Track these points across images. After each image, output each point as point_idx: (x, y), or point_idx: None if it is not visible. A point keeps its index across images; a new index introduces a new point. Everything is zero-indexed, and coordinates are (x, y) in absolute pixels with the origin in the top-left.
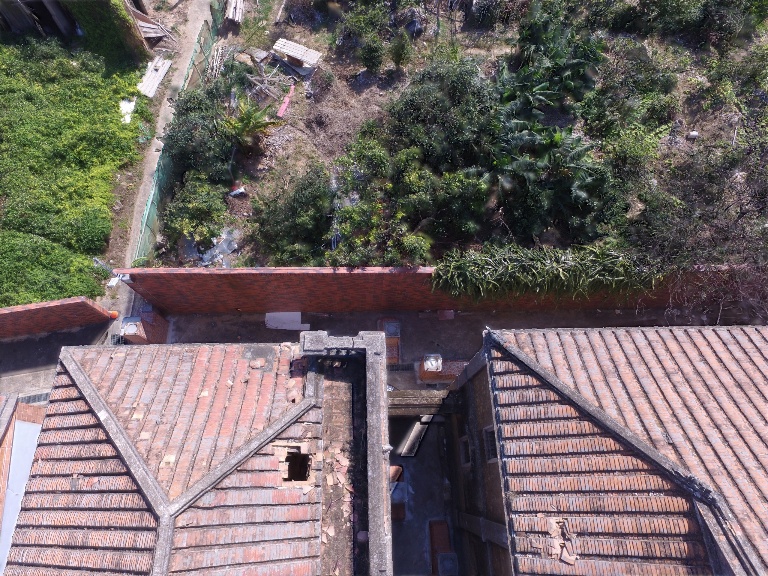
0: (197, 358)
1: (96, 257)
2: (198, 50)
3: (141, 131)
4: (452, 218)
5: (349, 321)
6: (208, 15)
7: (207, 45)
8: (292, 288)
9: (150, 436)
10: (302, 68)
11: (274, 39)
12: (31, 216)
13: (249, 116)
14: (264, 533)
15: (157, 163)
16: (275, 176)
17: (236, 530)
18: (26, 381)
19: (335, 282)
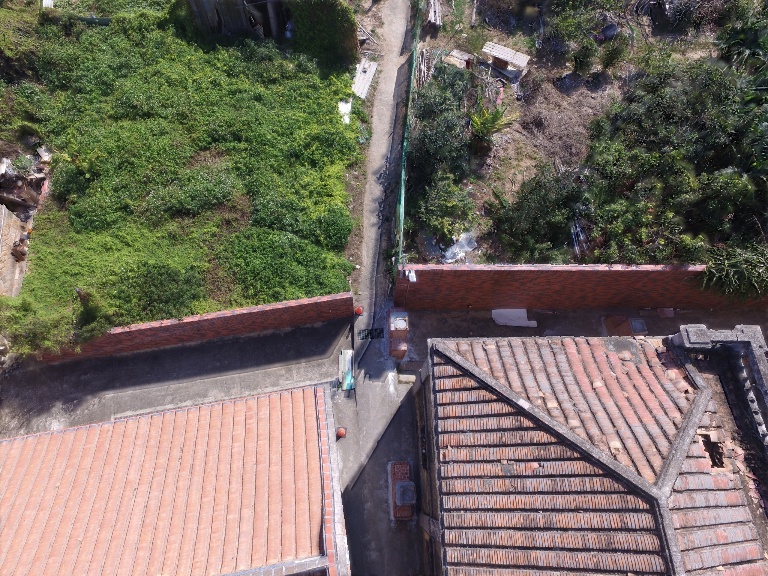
0: (567, 350)
1: (340, 254)
2: (398, 52)
3: (360, 131)
4: (704, 218)
5: (574, 318)
6: (401, 18)
7: (406, 48)
8: (549, 285)
9: (580, 424)
10: (508, 71)
11: (474, 42)
12: (282, 214)
13: (497, 117)
14: (719, 516)
15: (402, 163)
16: (501, 176)
17: (703, 513)
18: (280, 375)
19: (598, 279)
